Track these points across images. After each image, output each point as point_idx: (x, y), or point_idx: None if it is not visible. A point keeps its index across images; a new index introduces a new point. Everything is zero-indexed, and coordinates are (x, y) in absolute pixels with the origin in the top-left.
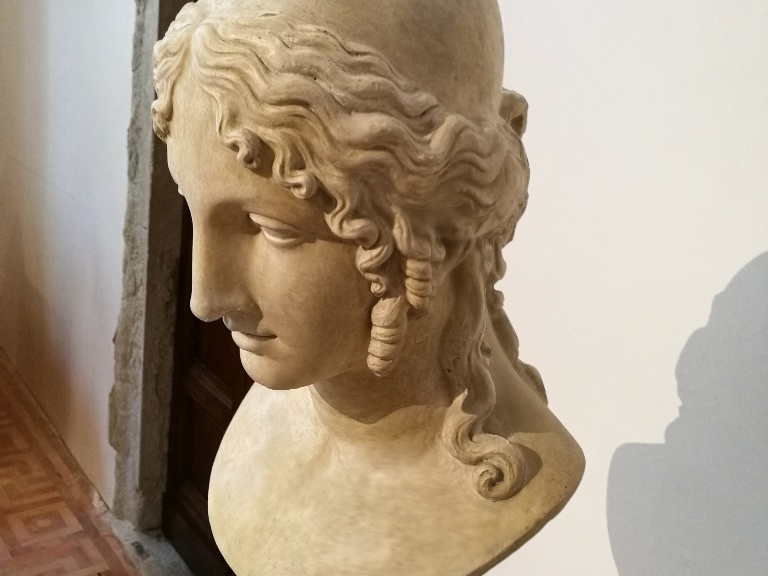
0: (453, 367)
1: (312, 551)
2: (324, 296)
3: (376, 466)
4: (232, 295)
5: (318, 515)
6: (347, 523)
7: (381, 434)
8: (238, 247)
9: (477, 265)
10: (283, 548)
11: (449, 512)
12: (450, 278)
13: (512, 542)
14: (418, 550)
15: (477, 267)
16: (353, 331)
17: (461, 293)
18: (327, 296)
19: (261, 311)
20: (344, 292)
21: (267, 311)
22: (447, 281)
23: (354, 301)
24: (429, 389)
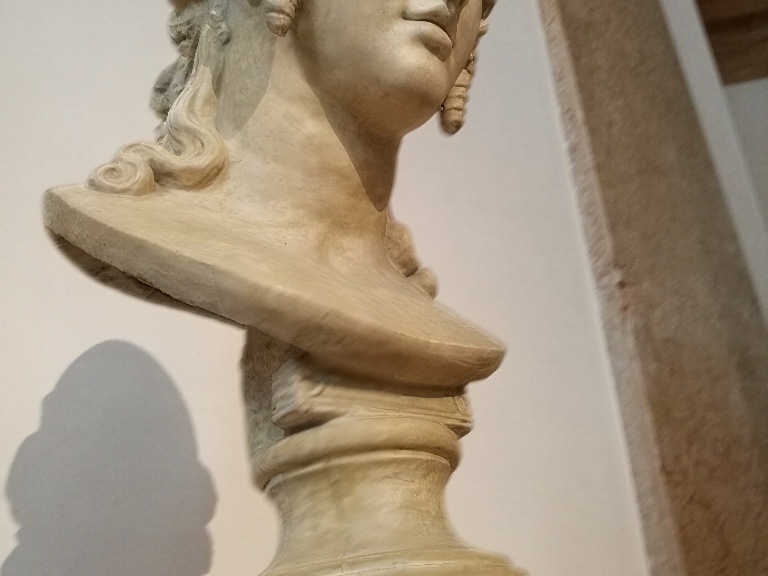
0: None
1: None
2: None
3: (379, 262)
4: None
5: None
6: (418, 297)
7: (380, 227)
8: None
9: None
10: None
11: None
12: None
13: None
14: None
15: None
16: None
17: None
18: None
19: (459, 17)
20: None
21: (464, 19)
22: None
23: None
24: None
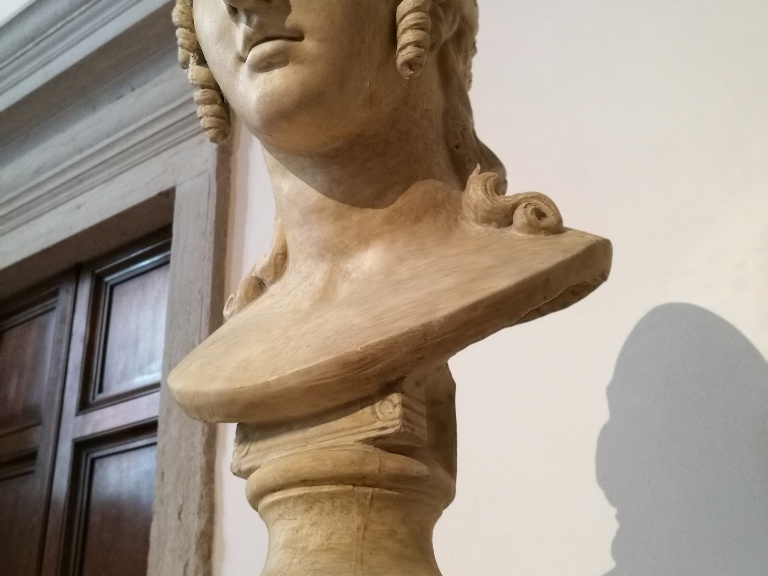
0: (461, 139)
1: (356, 315)
2: None
3: (401, 258)
4: None
5: (347, 305)
6: (389, 292)
7: (401, 218)
8: None
9: None
10: (313, 335)
11: (504, 249)
12: (438, 72)
13: (583, 247)
14: (488, 269)
15: None
16: (380, 34)
17: (449, 91)
18: None
19: (290, 4)
20: None
21: None
22: (436, 72)
23: None
24: (442, 166)
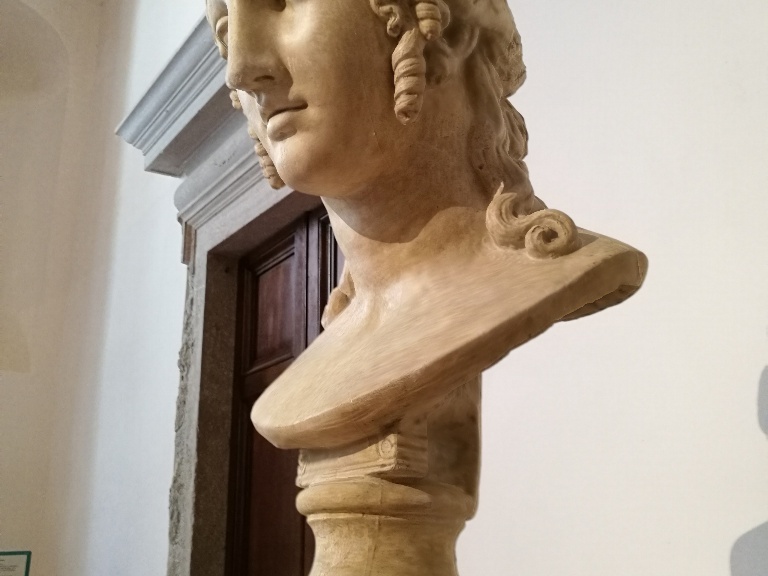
0: (484, 160)
1: (366, 360)
2: (345, 33)
3: (426, 288)
4: (264, 57)
5: (370, 344)
6: (402, 331)
7: (425, 249)
8: (267, 18)
9: (487, 77)
10: (335, 378)
11: (508, 279)
12: (465, 89)
13: (581, 273)
14: (481, 308)
15: (488, 79)
16: (377, 85)
17: (478, 105)
18: (348, 33)
19: (291, 76)
20: (363, 31)
21: (296, 70)
22: (462, 90)
23: (374, 45)
24: (465, 190)
